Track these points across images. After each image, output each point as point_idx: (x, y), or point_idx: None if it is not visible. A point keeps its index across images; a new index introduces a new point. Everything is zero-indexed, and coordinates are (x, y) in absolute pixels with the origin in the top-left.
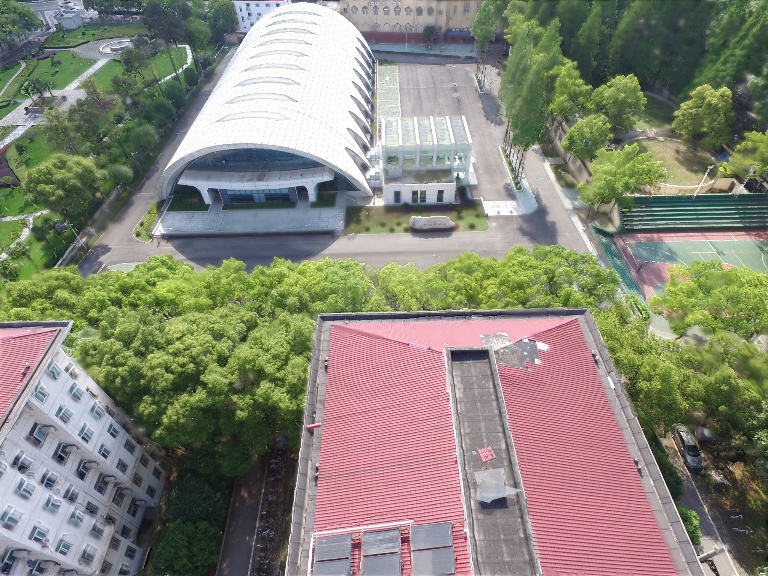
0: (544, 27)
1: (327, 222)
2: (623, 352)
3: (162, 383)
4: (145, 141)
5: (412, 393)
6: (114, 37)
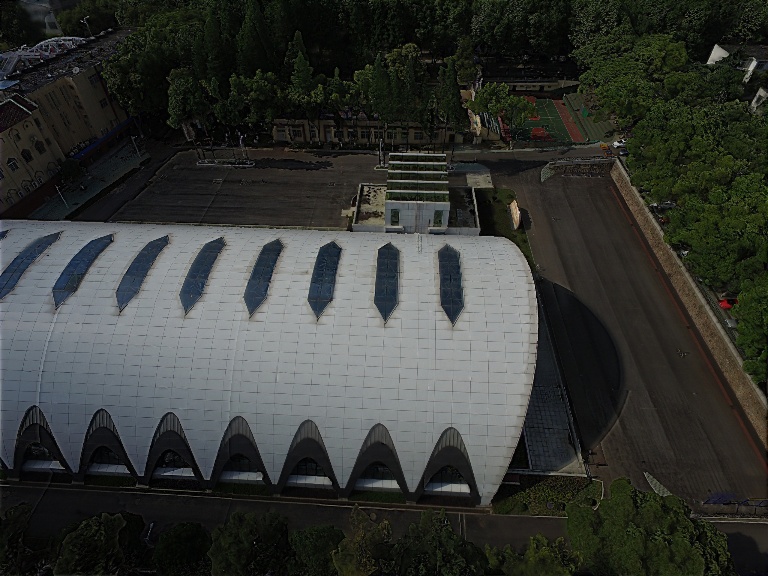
0: (252, 74)
1: None
2: (745, 103)
3: None
4: None
5: None
6: None
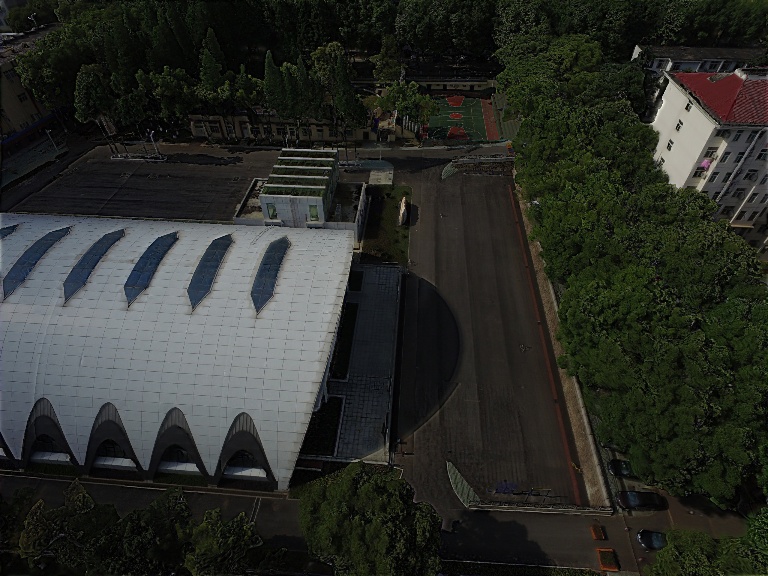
0: None
1: (388, 278)
2: None
3: None
4: (115, 519)
5: (766, 92)
6: None
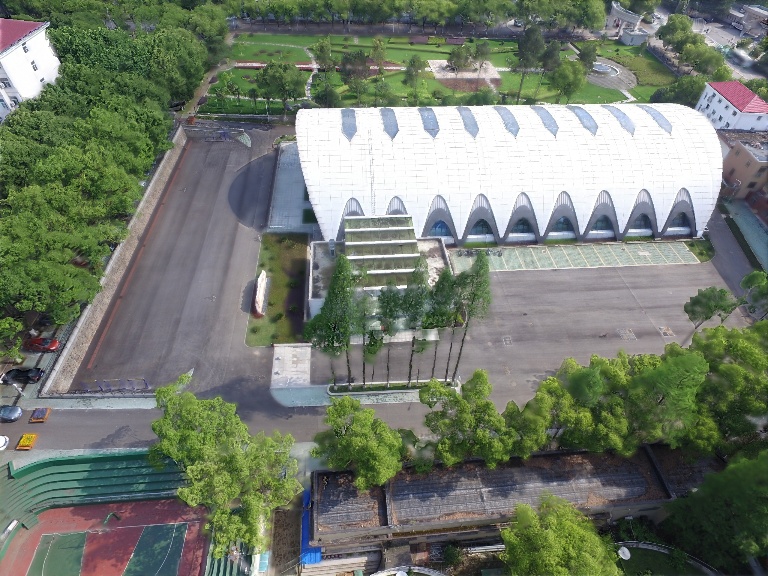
0: None
1: (280, 221)
2: None
3: (7, 116)
4: None
5: None
6: (621, 63)
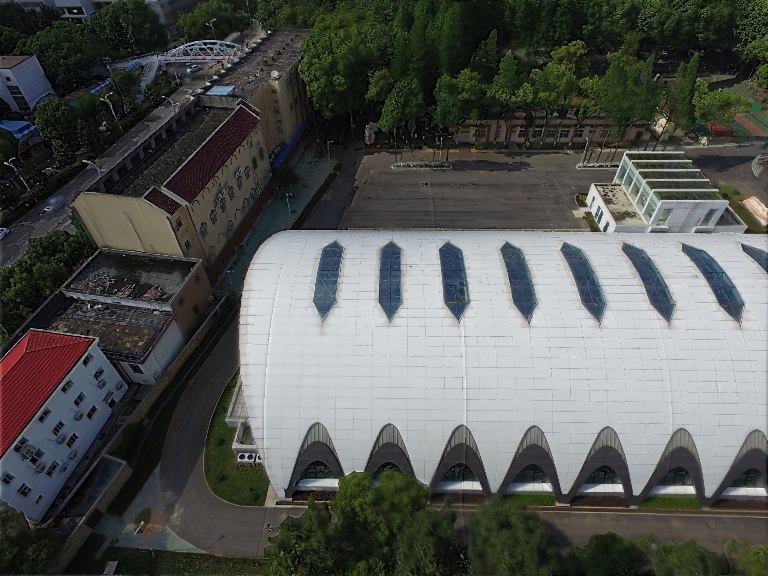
0: None
1: None
2: None
3: None
4: None
5: None
6: None
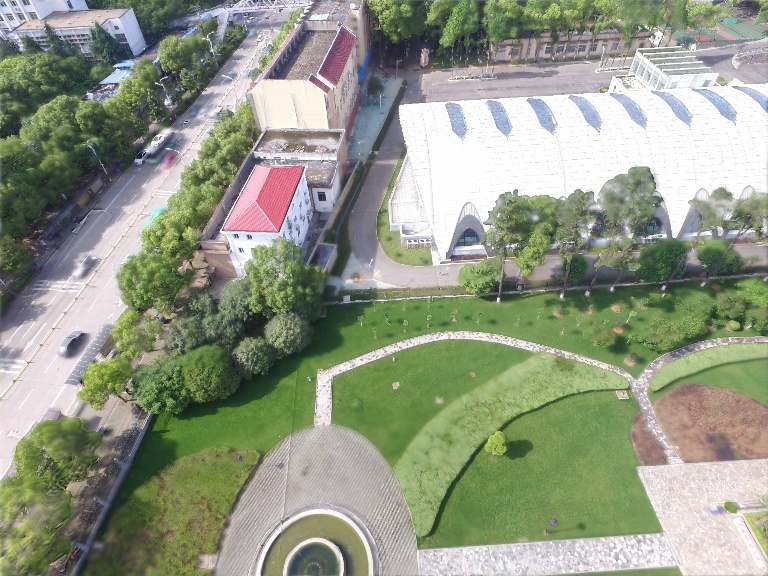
0: None
1: None
2: None
3: None
4: None
5: None
6: None
